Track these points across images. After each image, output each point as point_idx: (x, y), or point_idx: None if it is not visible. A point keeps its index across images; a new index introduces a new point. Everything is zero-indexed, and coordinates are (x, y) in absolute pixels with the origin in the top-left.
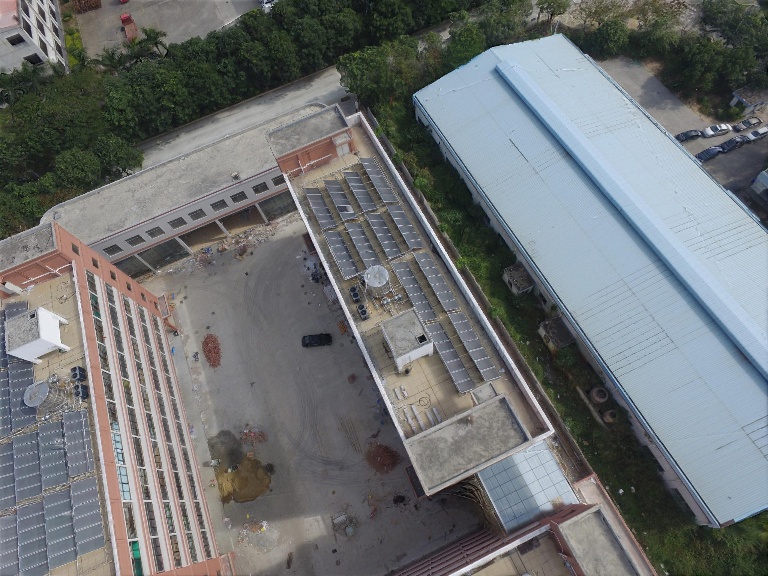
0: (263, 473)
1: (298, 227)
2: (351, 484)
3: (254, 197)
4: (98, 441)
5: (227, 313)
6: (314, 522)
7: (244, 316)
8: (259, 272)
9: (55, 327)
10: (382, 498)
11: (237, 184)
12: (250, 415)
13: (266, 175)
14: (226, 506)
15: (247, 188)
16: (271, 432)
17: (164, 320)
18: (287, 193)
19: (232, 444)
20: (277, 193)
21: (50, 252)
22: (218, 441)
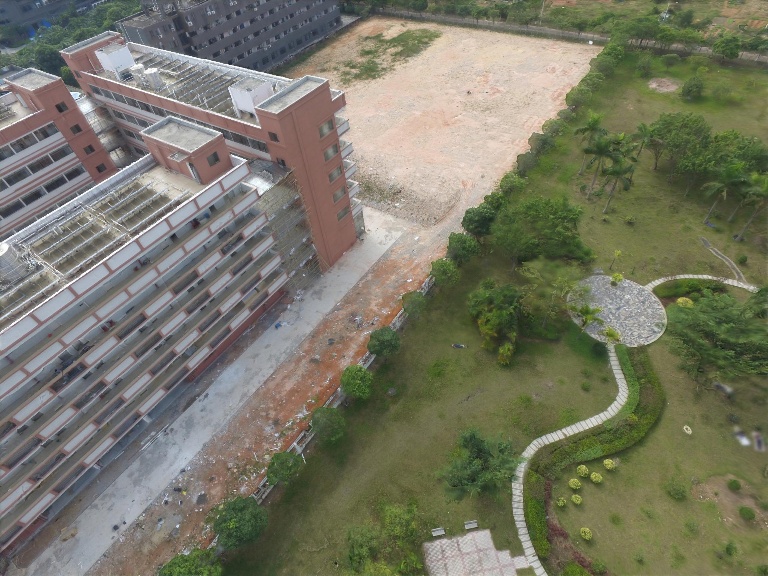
0: None
1: None
2: None
3: None
4: None
5: None
6: None
7: None
8: None
9: None
10: None
11: None
12: None
13: None
14: None
15: None
16: None
17: None
18: None
19: None
20: None
21: None
22: None
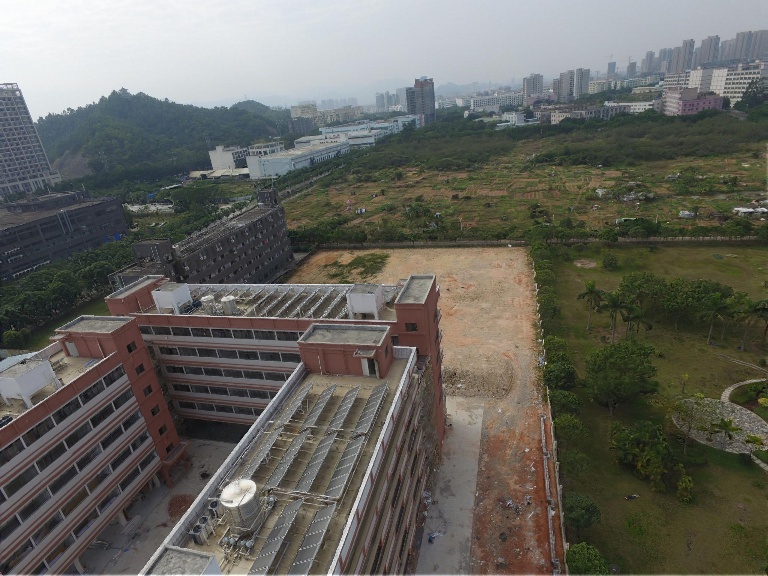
0: None
1: None
2: None
3: None
4: (242, 440)
5: None
6: None
7: None
8: None
9: None
10: None
11: None
12: None
13: None
14: None
15: None
16: None
17: None
18: None
19: None
20: None
21: None
22: None
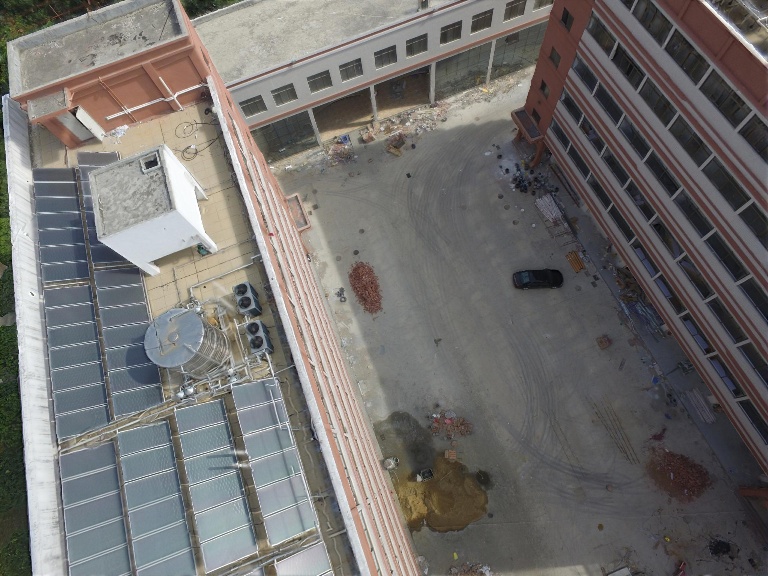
0: (473, 486)
1: (482, 111)
2: (629, 515)
3: (436, 49)
4: (328, 458)
5: (384, 232)
6: (573, 575)
7: (412, 237)
8: (428, 173)
9: (191, 197)
10: (689, 543)
11: (425, 16)
12: (439, 390)
13: (470, 6)
14: (416, 536)
15: (434, 28)
16: (478, 419)
17: (299, 234)
18: (479, 50)
19: (415, 435)
20: (467, 47)
21: (173, 41)
22: (391, 428)
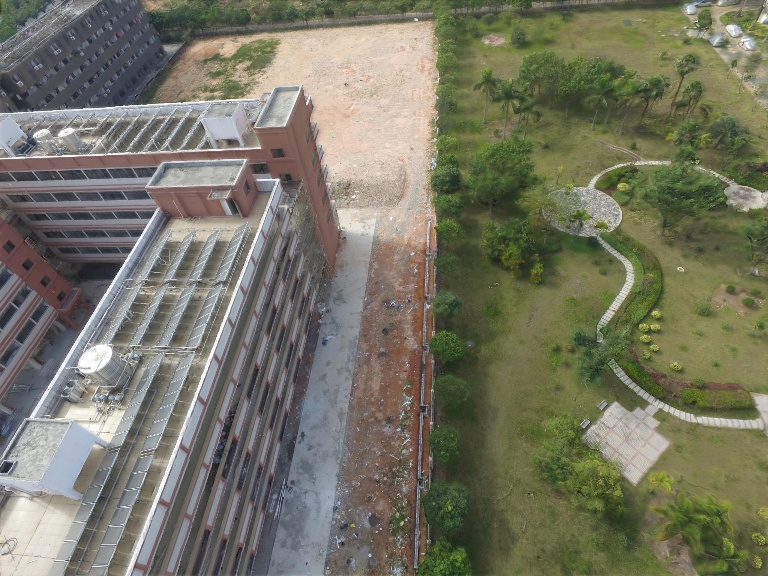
0: None
1: None
2: None
3: None
4: (101, 302)
5: None
6: None
7: None
8: None
9: None
10: None
11: None
12: None
13: None
14: None
15: None
16: None
17: None
18: None
19: None
20: None
21: None
22: None
